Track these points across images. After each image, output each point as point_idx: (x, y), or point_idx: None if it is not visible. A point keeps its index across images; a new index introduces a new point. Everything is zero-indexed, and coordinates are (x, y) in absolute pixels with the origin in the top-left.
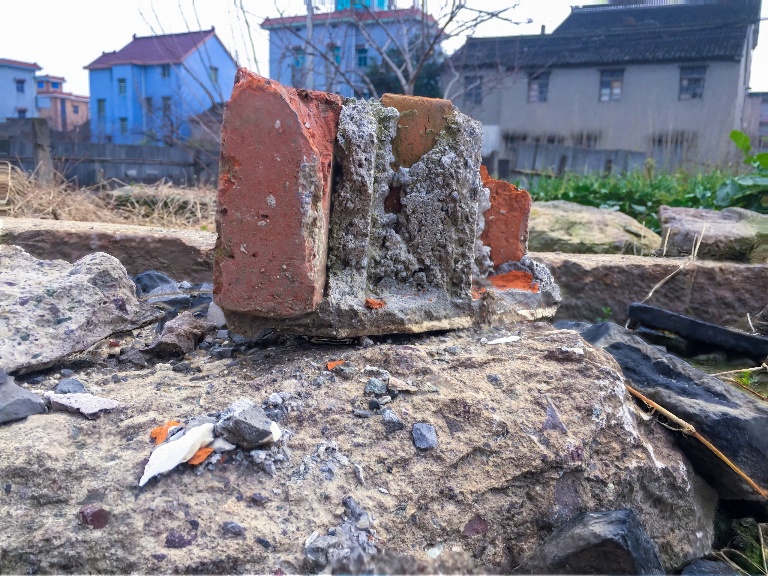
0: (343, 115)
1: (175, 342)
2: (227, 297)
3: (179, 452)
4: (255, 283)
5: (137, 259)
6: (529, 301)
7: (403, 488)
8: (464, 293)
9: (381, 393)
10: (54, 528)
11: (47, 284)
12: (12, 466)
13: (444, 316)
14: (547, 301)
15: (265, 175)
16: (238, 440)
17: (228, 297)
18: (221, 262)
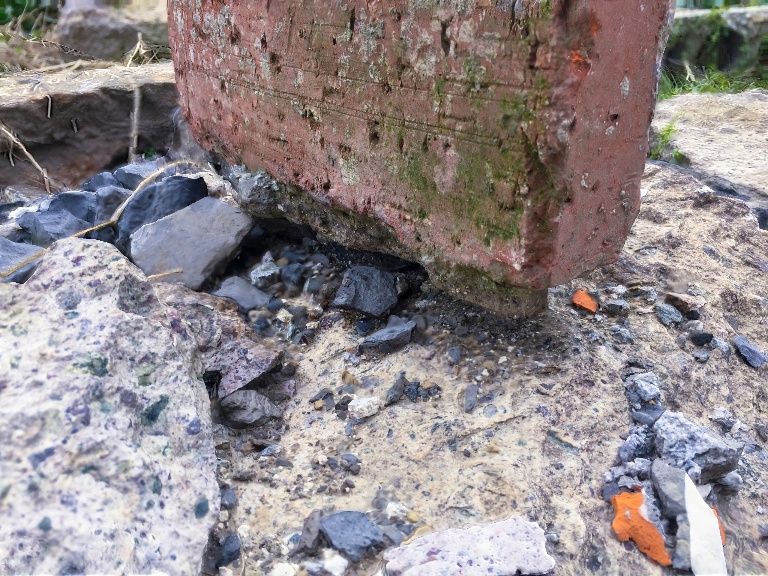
0: None
1: (278, 350)
2: (558, 268)
3: (721, 544)
4: (589, 231)
5: None
6: None
7: None
8: None
9: (680, 319)
10: None
11: (60, 351)
12: None
13: None
14: None
15: (624, 41)
16: (712, 475)
17: (559, 268)
18: (553, 214)
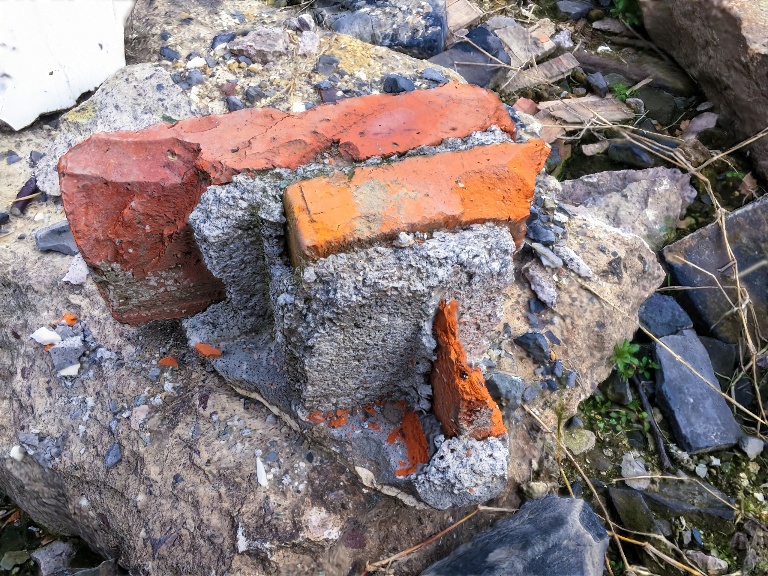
0: (204, 197)
1: None
2: None
3: None
4: None
5: (697, 19)
6: (383, 472)
7: (85, 461)
8: (299, 407)
9: None
10: (10, 323)
11: None
12: (18, 283)
13: (276, 404)
14: (414, 492)
15: None
16: None
17: None
18: None
